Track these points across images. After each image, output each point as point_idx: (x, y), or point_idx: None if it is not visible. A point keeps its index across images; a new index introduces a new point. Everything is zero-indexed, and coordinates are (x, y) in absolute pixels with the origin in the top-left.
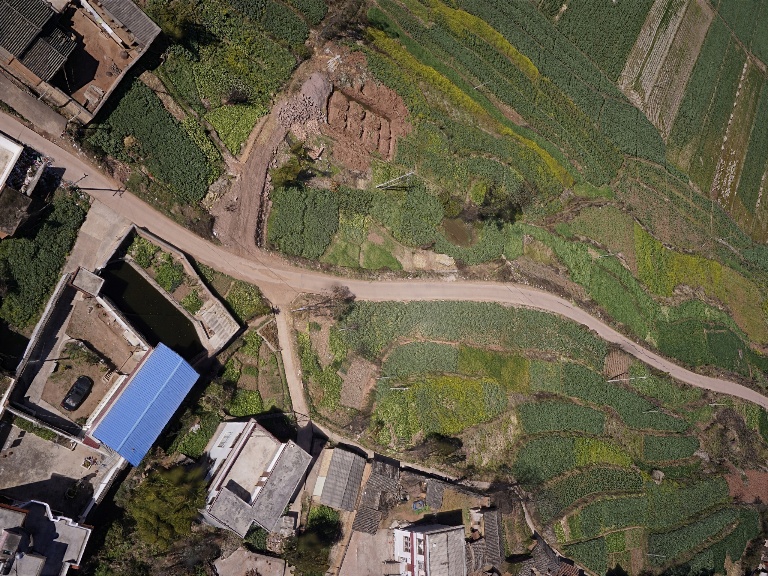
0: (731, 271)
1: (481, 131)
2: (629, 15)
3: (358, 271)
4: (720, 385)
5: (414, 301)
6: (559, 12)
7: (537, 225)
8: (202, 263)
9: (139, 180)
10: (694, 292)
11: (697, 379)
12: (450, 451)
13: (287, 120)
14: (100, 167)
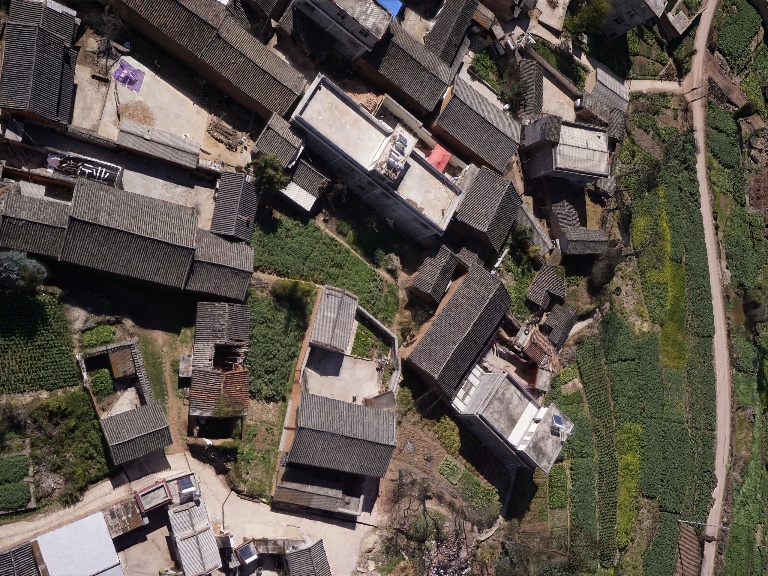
0: None
1: None
2: None
3: None
4: None
5: None
6: None
7: (761, 434)
8: (696, 32)
9: None
10: None
11: None
12: (620, 230)
13: (766, 133)
14: None
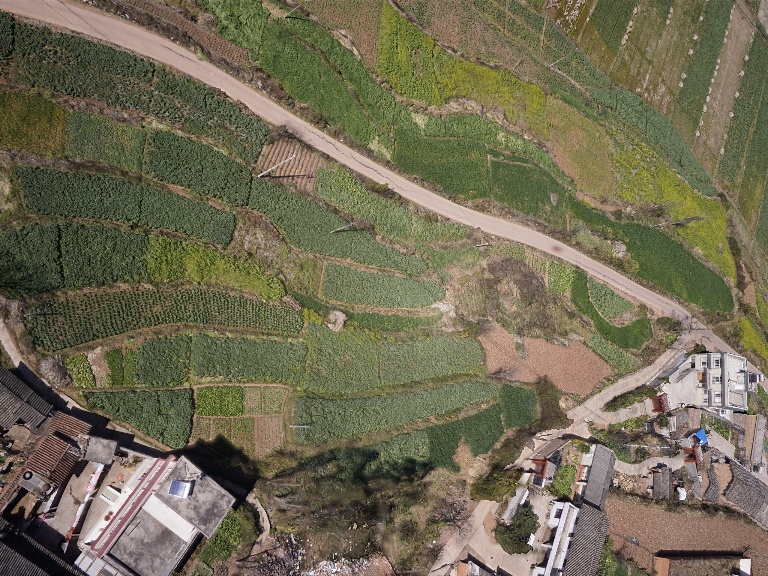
0: (564, 105)
1: None
2: None
3: None
4: (505, 228)
5: None
6: None
7: None
8: None
9: None
10: (485, 111)
11: (461, 213)
12: None
13: None
14: None
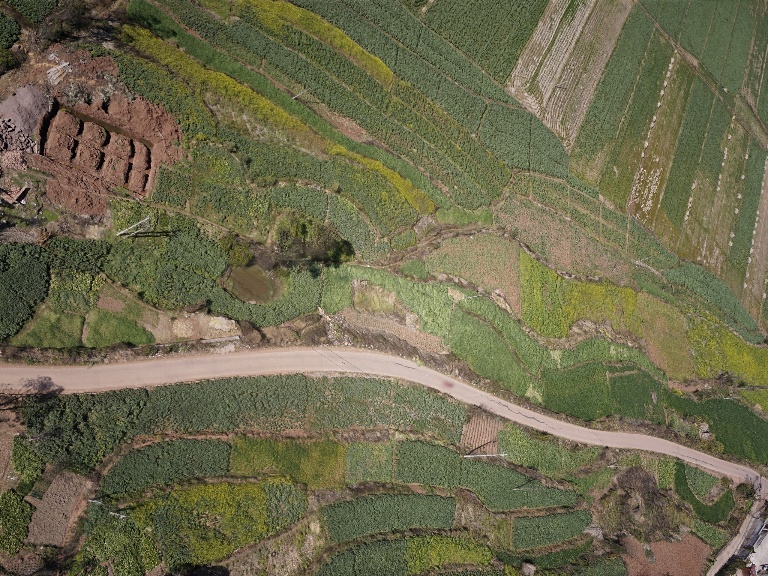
0: (649, 297)
1: (298, 152)
2: (523, 5)
3: (68, 354)
4: (625, 439)
5: (163, 385)
6: (427, 2)
7: (375, 266)
8: None
9: None
10: (598, 328)
11: (594, 436)
12: None
13: None
14: None
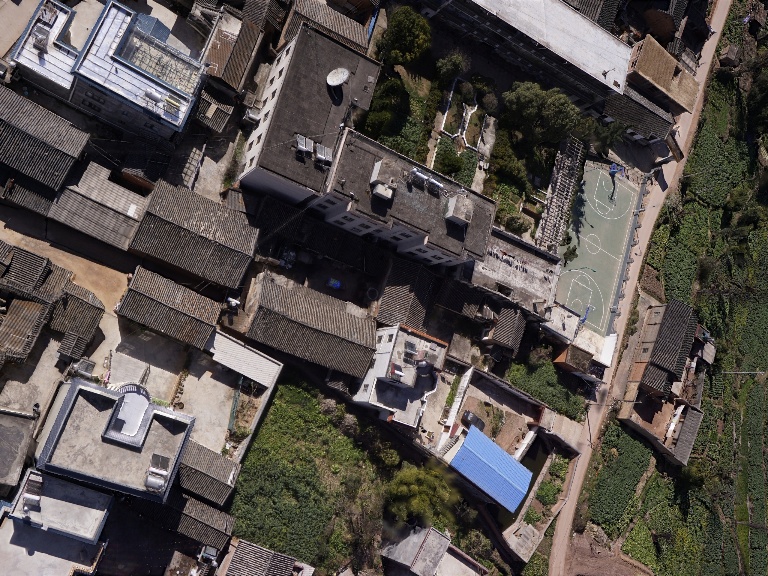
0: None
1: None
2: None
3: None
4: None
5: None
6: None
7: None
8: (556, 524)
9: (598, 460)
10: None
11: None
12: None
13: None
14: (602, 427)
